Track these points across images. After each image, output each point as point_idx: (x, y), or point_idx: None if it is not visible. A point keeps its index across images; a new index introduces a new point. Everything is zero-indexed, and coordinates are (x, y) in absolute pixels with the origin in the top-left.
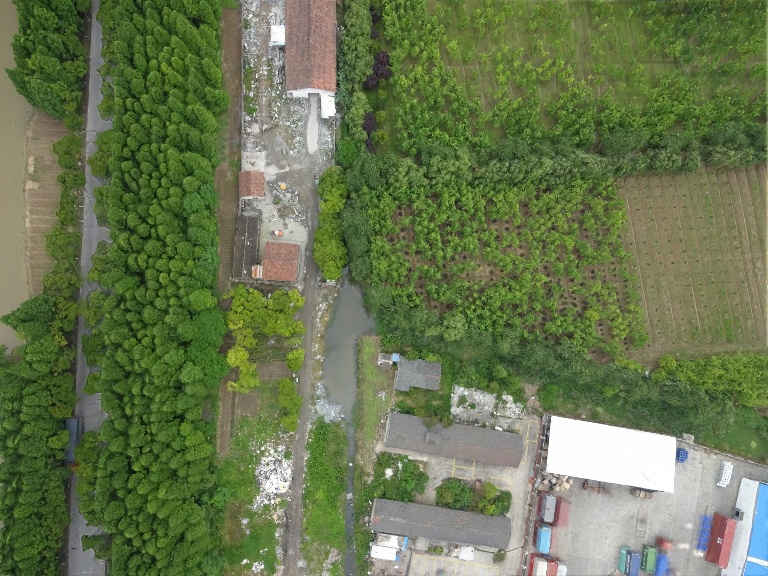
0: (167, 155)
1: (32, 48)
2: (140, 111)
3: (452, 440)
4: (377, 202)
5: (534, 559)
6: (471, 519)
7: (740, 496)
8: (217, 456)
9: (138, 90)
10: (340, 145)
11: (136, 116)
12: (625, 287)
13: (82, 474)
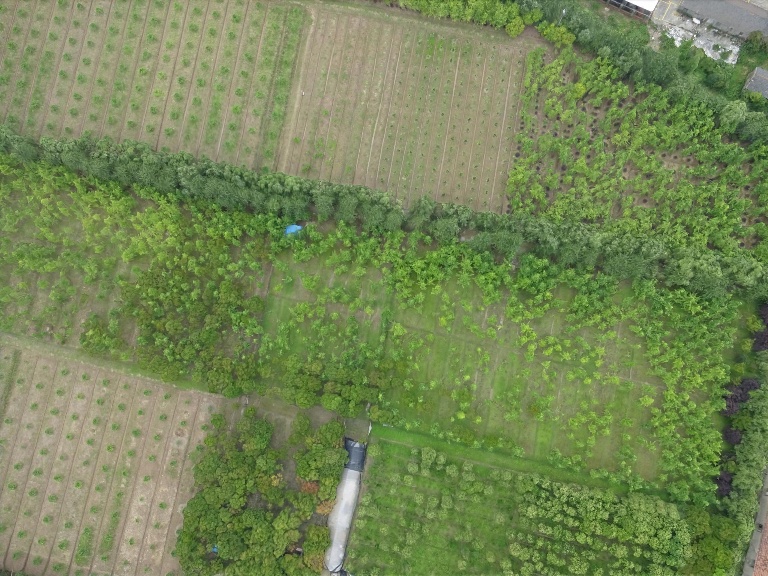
0: None
1: None
2: None
3: (759, 17)
4: None
5: None
6: None
7: None
8: None
9: None
10: None
11: None
12: None
13: None
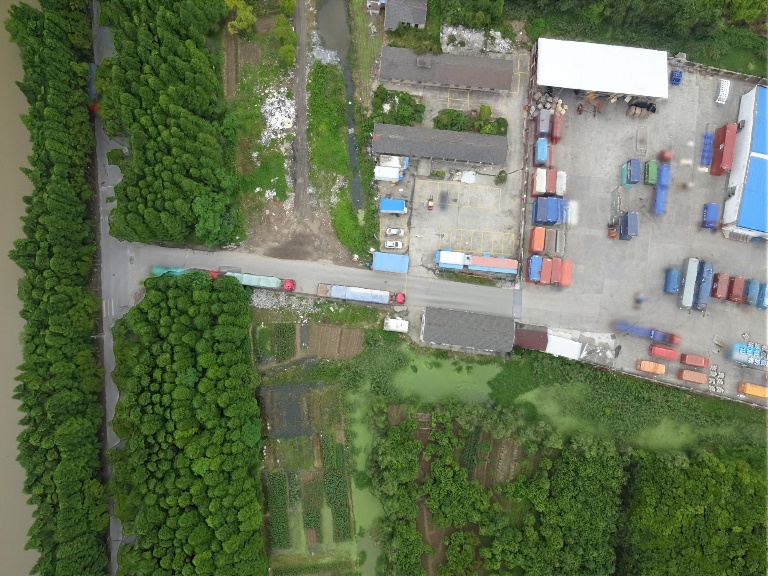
0: None
1: None
2: None
3: (443, 63)
4: None
5: (534, 173)
6: (468, 136)
7: (741, 111)
8: (225, 98)
9: None
10: None
11: None
12: None
13: (102, 88)
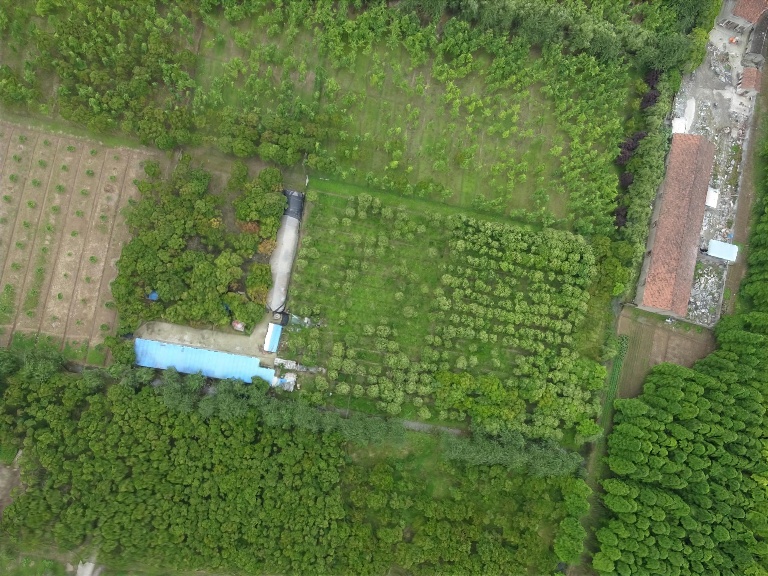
0: None
1: None
2: None
3: None
4: None
5: None
6: None
7: None
8: None
9: None
10: None
11: None
12: None
13: None
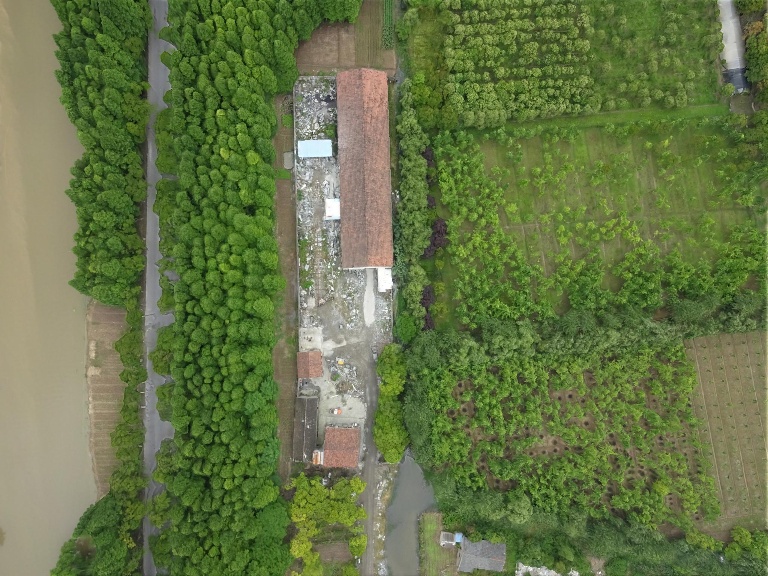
0: (228, 360)
1: (92, 250)
2: (200, 313)
3: None
4: (437, 382)
5: None
6: None
7: None
8: None
9: (198, 293)
10: (398, 322)
11: (196, 319)
12: (695, 452)
13: None
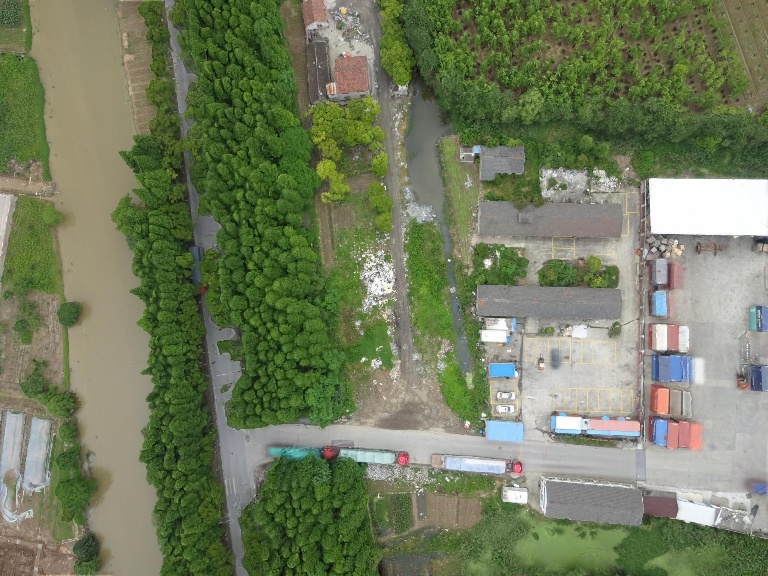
0: None
1: None
2: None
3: (546, 217)
4: None
5: (652, 326)
6: (578, 293)
7: None
8: (323, 267)
9: None
10: None
11: None
12: (714, 39)
13: (208, 283)
